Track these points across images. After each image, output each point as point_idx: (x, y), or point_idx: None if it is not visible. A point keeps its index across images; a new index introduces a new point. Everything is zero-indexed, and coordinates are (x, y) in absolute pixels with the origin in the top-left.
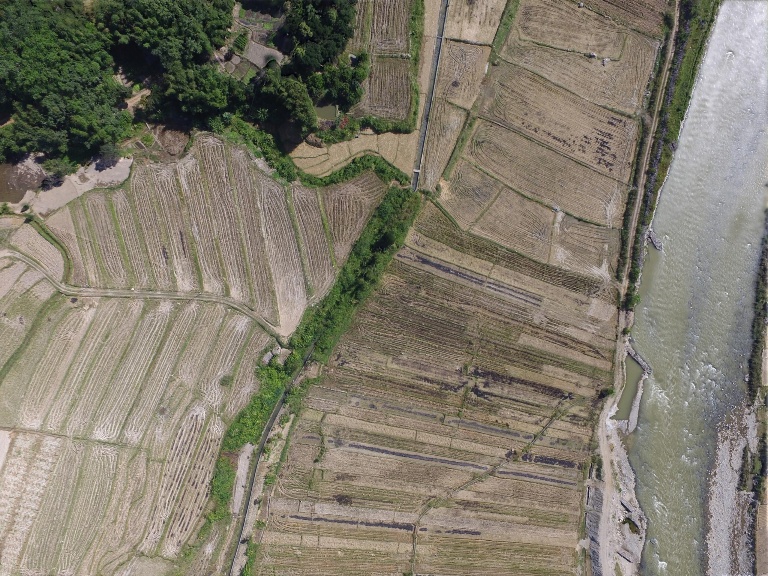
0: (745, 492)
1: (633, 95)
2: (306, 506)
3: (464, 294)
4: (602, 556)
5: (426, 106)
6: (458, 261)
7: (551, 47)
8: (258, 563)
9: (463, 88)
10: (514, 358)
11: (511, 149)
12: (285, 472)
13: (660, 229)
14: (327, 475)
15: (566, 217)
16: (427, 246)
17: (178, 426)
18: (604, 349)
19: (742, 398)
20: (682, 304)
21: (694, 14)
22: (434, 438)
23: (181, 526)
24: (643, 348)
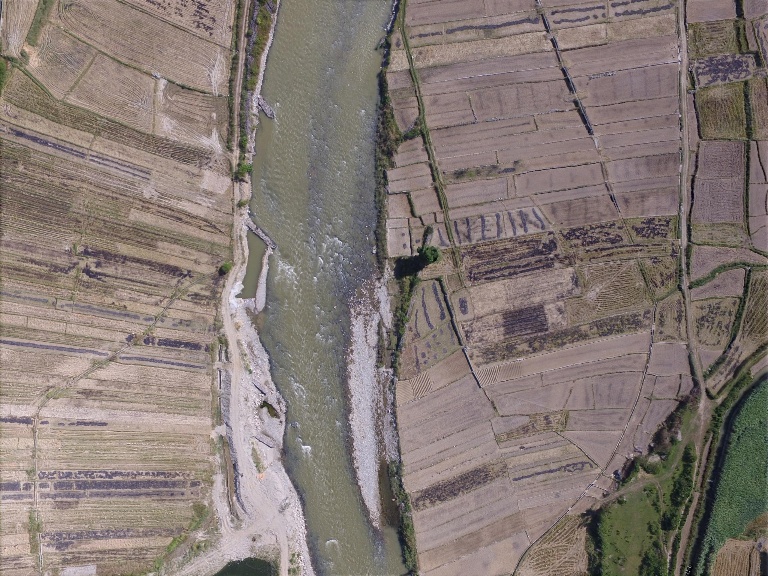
0: (384, 369)
1: None
2: None
3: (65, 168)
4: (236, 441)
5: None
6: (55, 133)
7: None
8: None
9: None
10: (126, 235)
11: (102, 12)
12: None
13: (270, 96)
14: None
15: (169, 85)
16: (20, 117)
17: None
18: (221, 223)
19: (371, 271)
20: (300, 175)
21: None
22: (47, 324)
23: None
24: (264, 222)
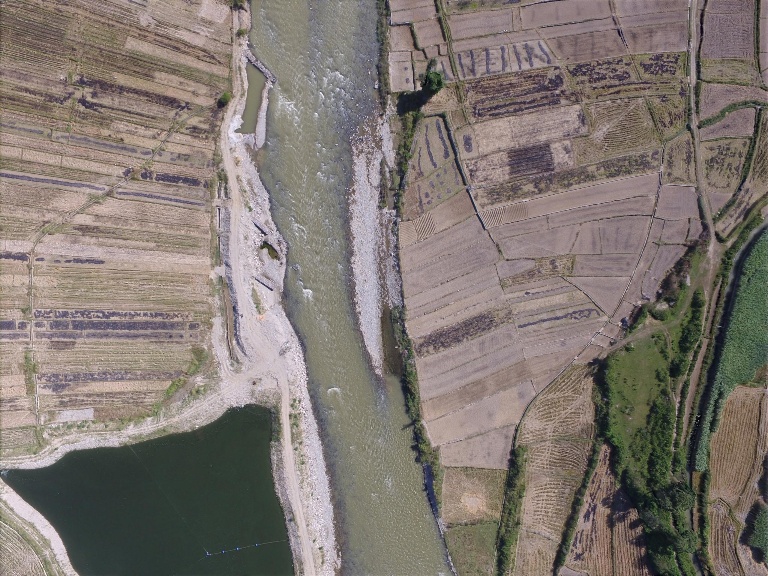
0: (387, 210)
1: None
2: None
3: None
4: (235, 280)
5: None
6: None
7: None
8: None
9: None
10: (122, 64)
11: None
12: None
13: None
14: None
15: None
16: None
17: None
18: (220, 54)
19: (374, 107)
20: (301, 5)
21: None
22: (42, 156)
23: None
24: (263, 53)
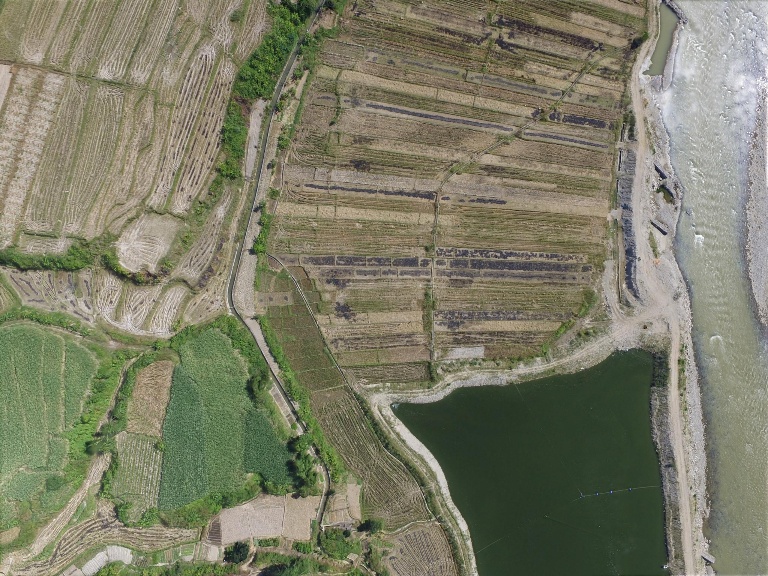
0: None
1: None
2: (322, 174)
3: None
4: (635, 223)
5: None
6: None
7: None
8: (272, 237)
9: None
10: (541, 5)
11: None
12: (299, 136)
13: None
14: (344, 138)
15: None
16: None
17: (187, 67)
18: None
19: None
20: None
21: None
22: (456, 96)
23: (191, 179)
24: None
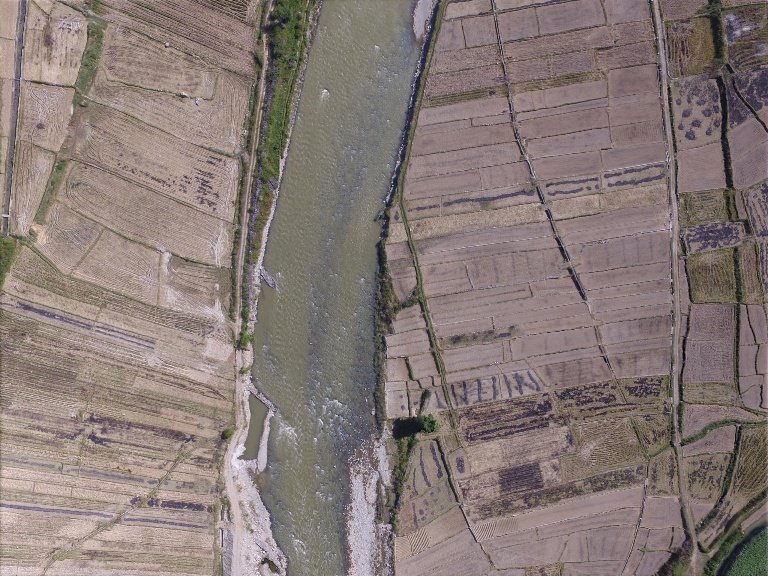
0: (383, 525)
1: (231, 134)
2: None
3: (72, 339)
4: None
5: (10, 149)
6: (62, 306)
7: (141, 87)
8: None
9: (49, 130)
10: (130, 402)
11: (109, 191)
12: None
13: (271, 267)
14: None
15: (173, 258)
16: (28, 292)
17: None
18: (224, 389)
19: (370, 432)
20: (301, 341)
21: (276, 53)
22: (53, 488)
23: None
24: (265, 386)
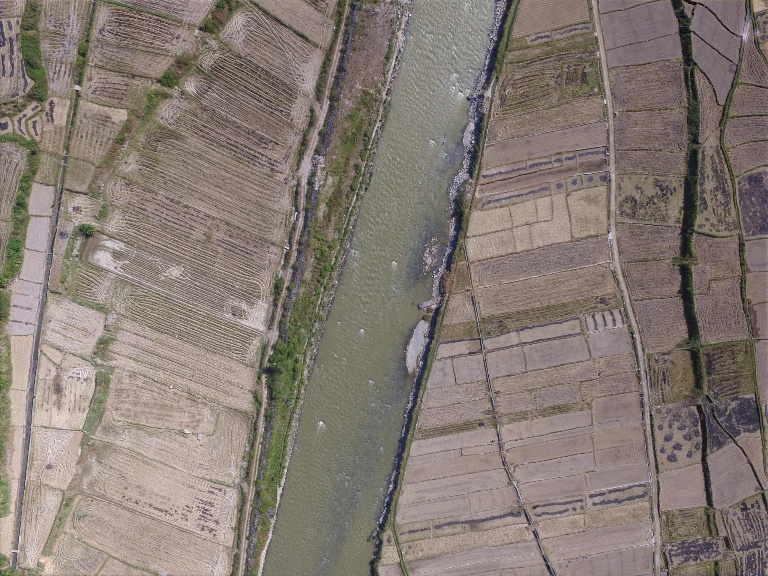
0: None
1: (231, 465)
2: None
3: None
4: None
5: (20, 489)
6: None
7: (145, 426)
8: None
9: (58, 470)
10: None
11: (114, 521)
12: None
13: None
14: None
15: None
16: None
17: None
18: None
19: None
20: None
21: (275, 398)
22: None
23: None
24: None
